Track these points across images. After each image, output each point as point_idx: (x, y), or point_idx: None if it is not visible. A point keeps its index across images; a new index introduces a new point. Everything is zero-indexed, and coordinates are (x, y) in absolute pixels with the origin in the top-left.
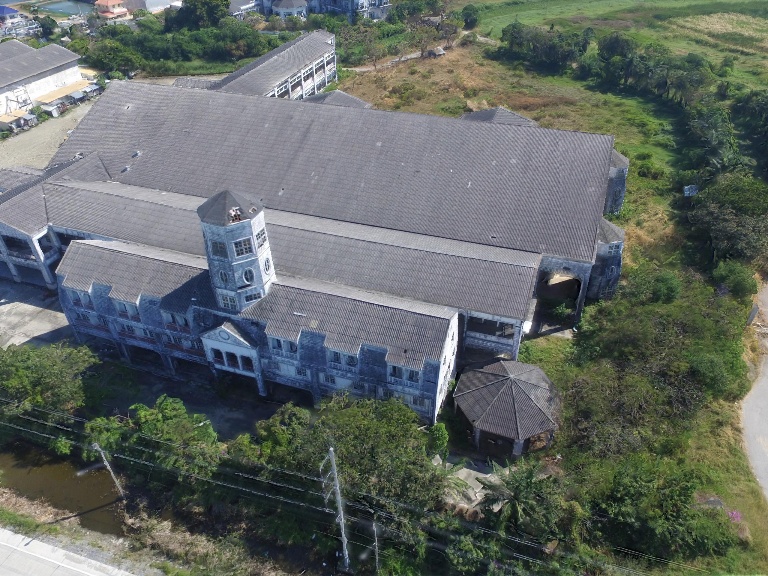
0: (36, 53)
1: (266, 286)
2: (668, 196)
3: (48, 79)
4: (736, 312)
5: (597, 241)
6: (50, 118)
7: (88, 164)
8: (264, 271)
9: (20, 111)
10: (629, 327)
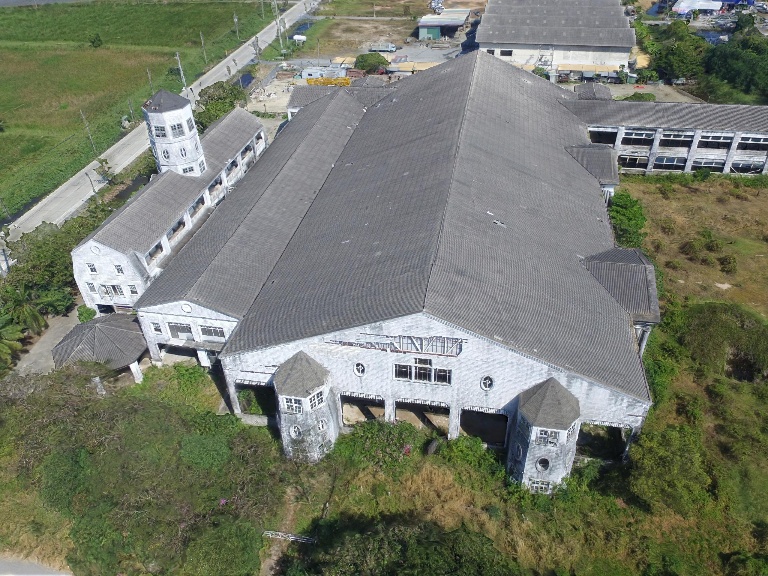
0: (606, 30)
1: (165, 168)
2: None
3: (589, 54)
4: (155, 536)
5: (246, 349)
6: None
7: (379, 93)
8: (163, 156)
9: (533, 66)
10: (126, 397)
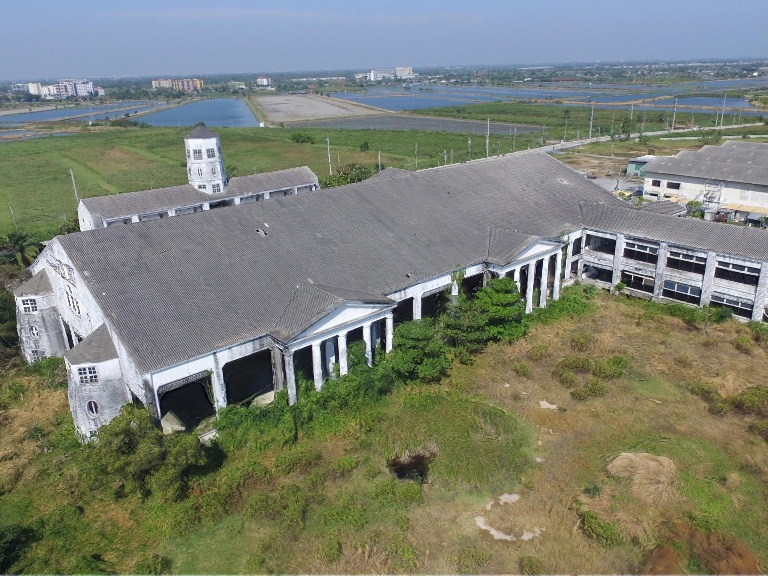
0: None
1: None
2: (6, 526)
3: None
4: None
5: None
6: (699, 217)
7: None
8: None
9: None
10: None
